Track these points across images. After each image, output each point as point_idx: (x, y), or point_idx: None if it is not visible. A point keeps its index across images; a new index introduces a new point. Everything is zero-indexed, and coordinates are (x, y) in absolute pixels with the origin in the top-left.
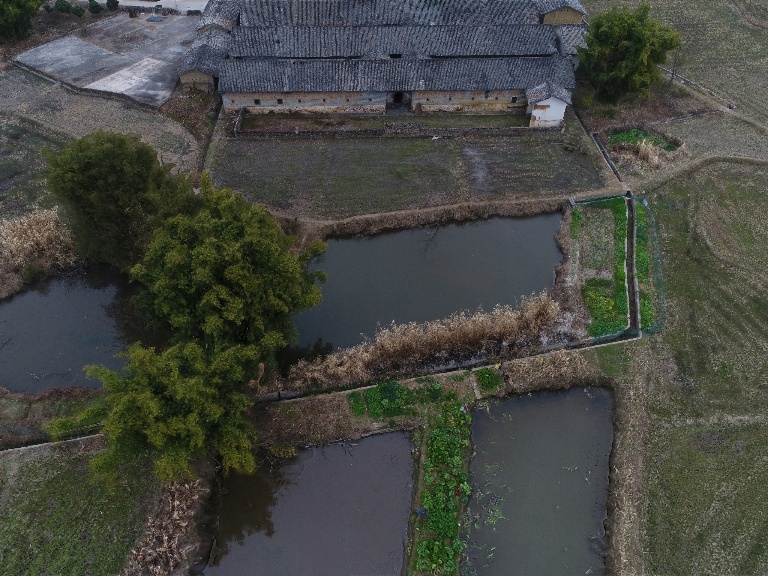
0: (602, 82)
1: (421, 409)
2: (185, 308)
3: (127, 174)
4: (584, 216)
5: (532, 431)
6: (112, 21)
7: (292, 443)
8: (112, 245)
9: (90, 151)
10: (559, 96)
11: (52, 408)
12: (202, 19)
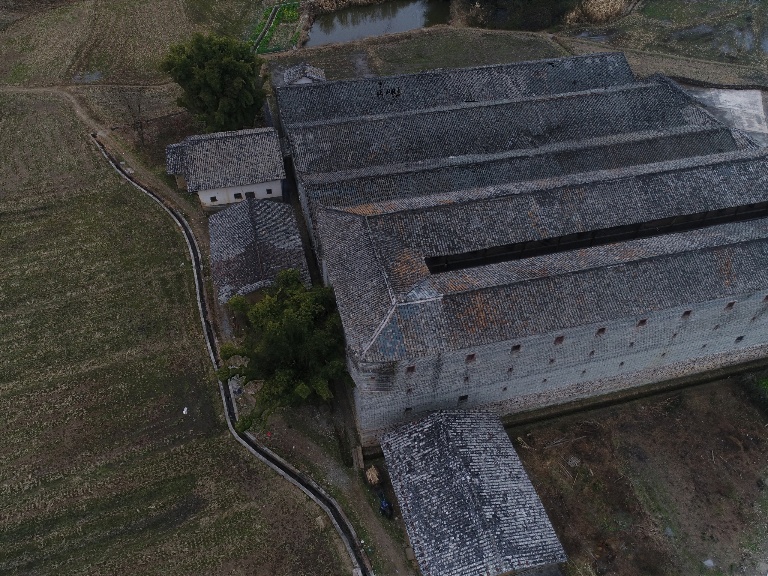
0: None
1: None
2: None
3: None
4: None
5: None
6: None
7: None
8: None
9: None
10: (296, 68)
11: None
12: None
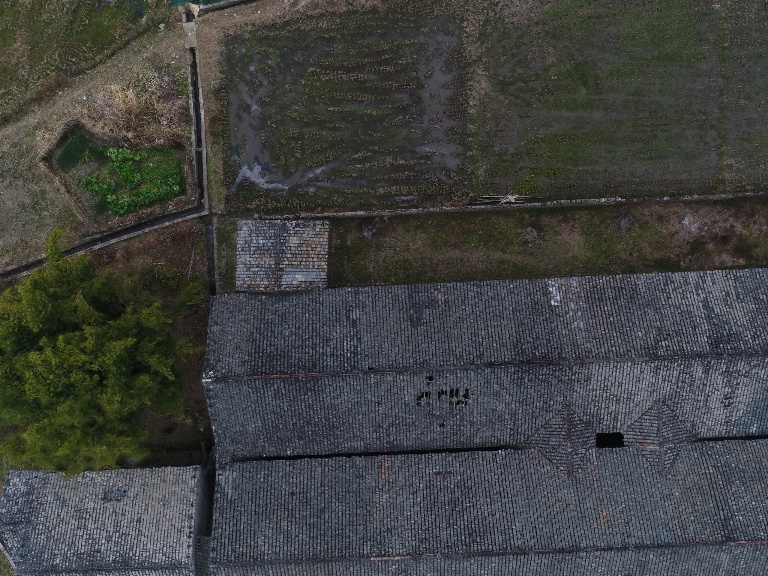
0: None
1: None
2: None
3: None
4: None
5: None
6: None
7: None
8: None
9: None
10: (263, 232)
11: None
12: None
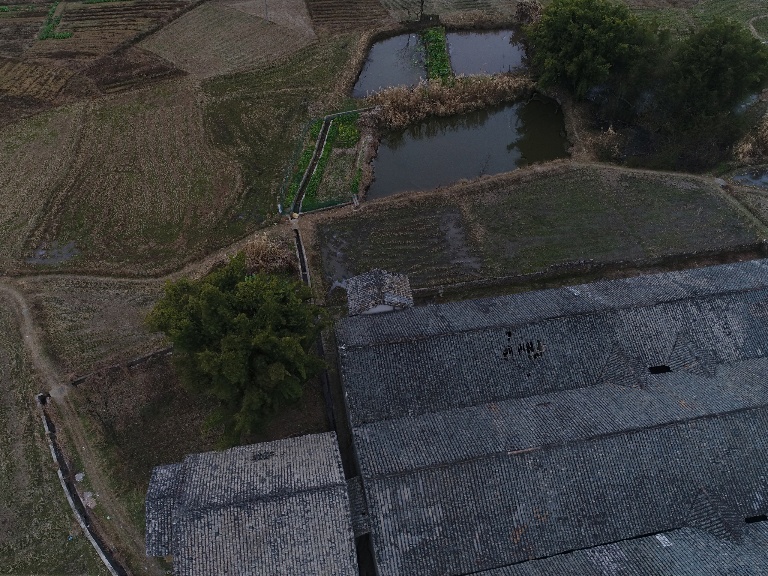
0: None
1: None
2: None
3: None
4: None
5: None
6: None
7: None
8: None
9: None
10: (366, 278)
11: None
12: None
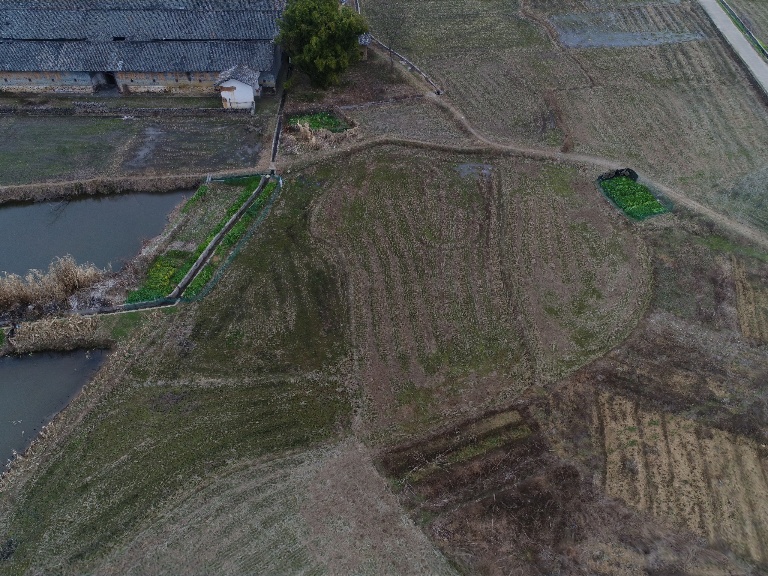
0: None
1: None
2: None
3: None
4: (214, 192)
5: (9, 388)
6: None
7: None
8: None
9: None
10: (241, 78)
11: None
12: None
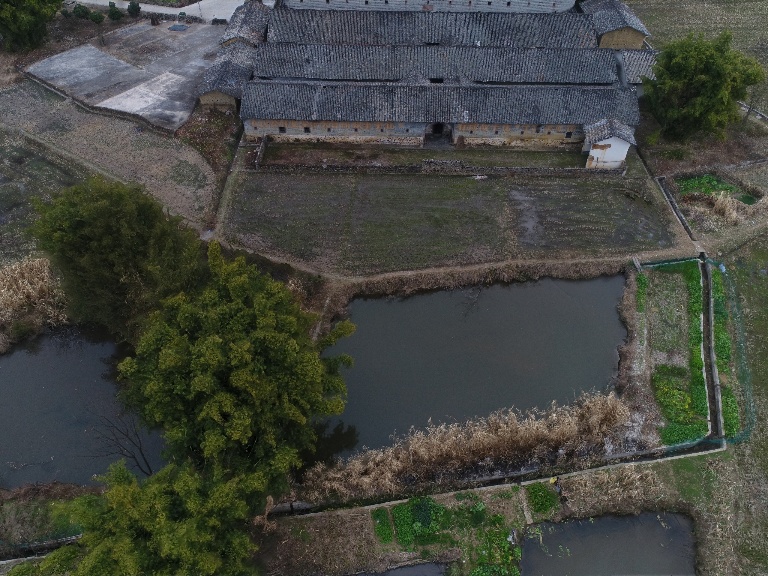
0: (671, 119)
1: (460, 536)
2: (182, 412)
3: (124, 237)
4: (651, 282)
5: (595, 571)
6: (132, 29)
7: (304, 574)
8: (107, 312)
9: (82, 209)
10: (622, 135)
11: (26, 511)
12: (227, 31)
